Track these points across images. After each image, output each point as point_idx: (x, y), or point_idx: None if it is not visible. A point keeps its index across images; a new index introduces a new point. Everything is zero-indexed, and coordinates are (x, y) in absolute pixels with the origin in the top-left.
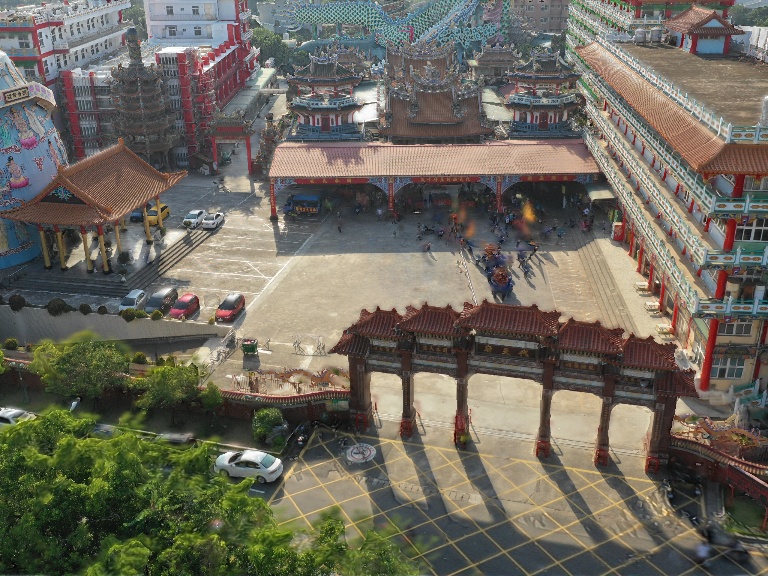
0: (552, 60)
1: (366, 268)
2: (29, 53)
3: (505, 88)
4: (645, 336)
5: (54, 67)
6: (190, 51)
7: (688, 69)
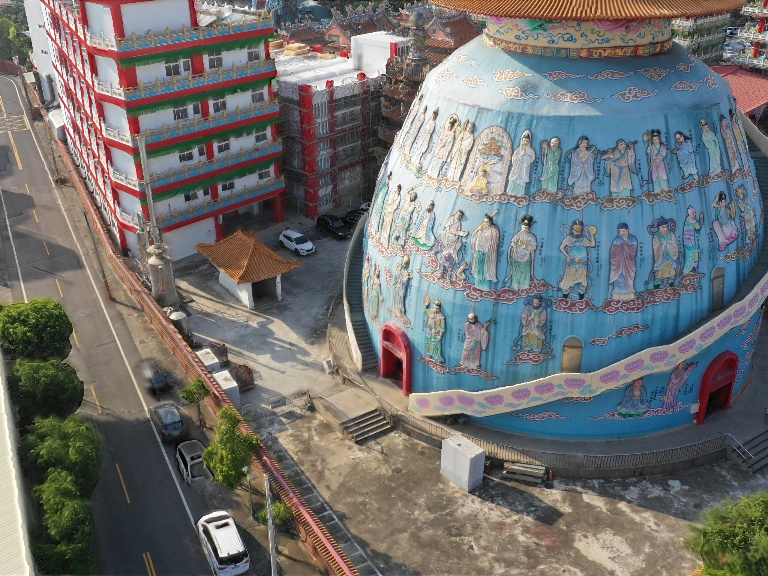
0: None
1: None
2: (267, 67)
3: None
4: None
5: None
6: None
7: None
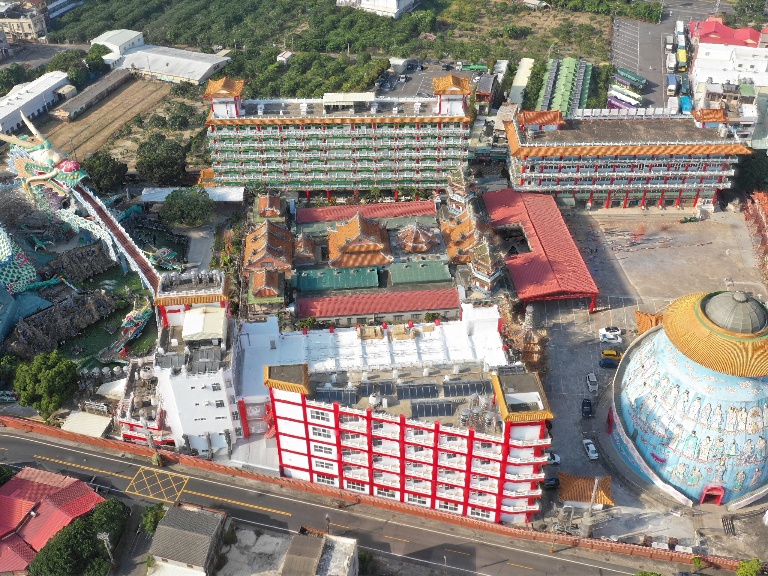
0: None
1: (646, 276)
2: None
3: (304, 218)
4: (683, 212)
5: None
6: None
7: (610, 135)
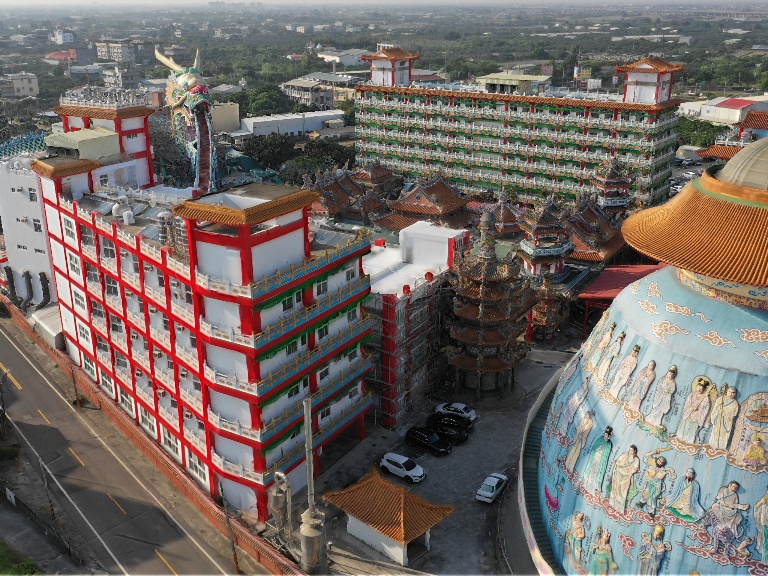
0: (617, 165)
1: None
2: (364, 285)
3: None
4: None
5: None
6: None
7: None
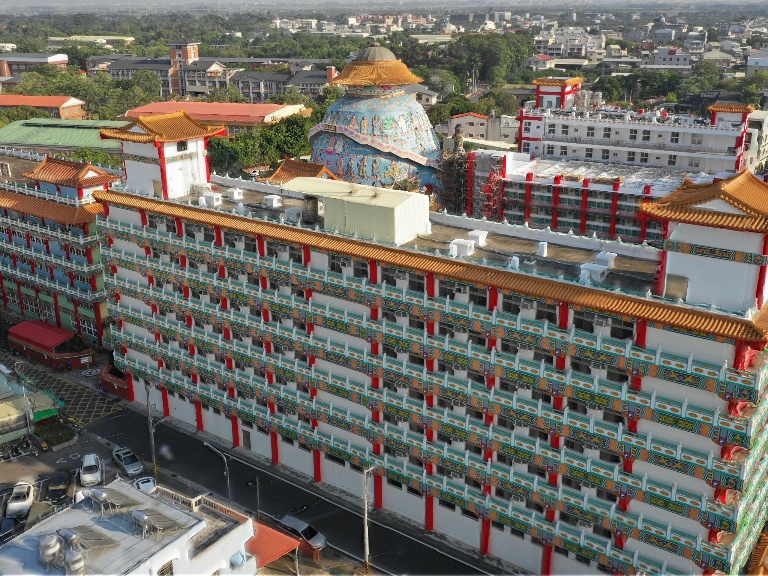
0: None
1: None
2: None
3: None
4: None
5: (540, 150)
6: (483, 154)
7: None
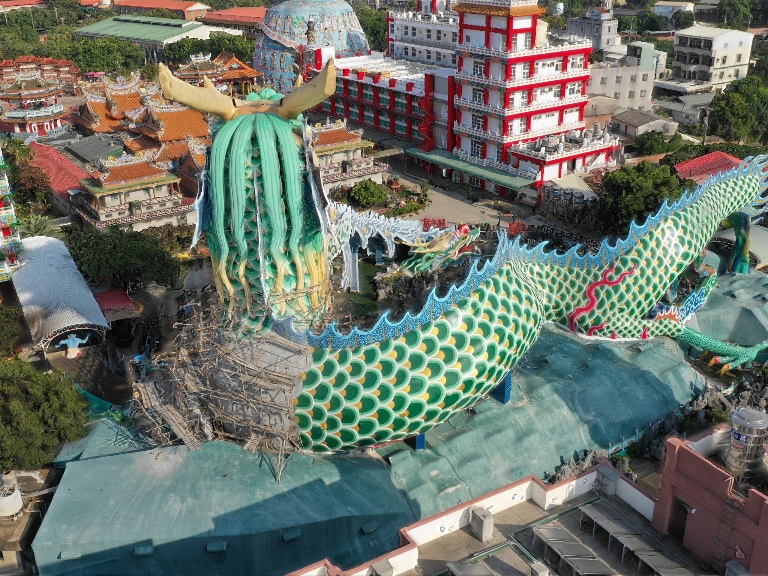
0: (23, 80)
1: None
2: None
3: None
4: None
5: None
6: (305, 47)
7: None
